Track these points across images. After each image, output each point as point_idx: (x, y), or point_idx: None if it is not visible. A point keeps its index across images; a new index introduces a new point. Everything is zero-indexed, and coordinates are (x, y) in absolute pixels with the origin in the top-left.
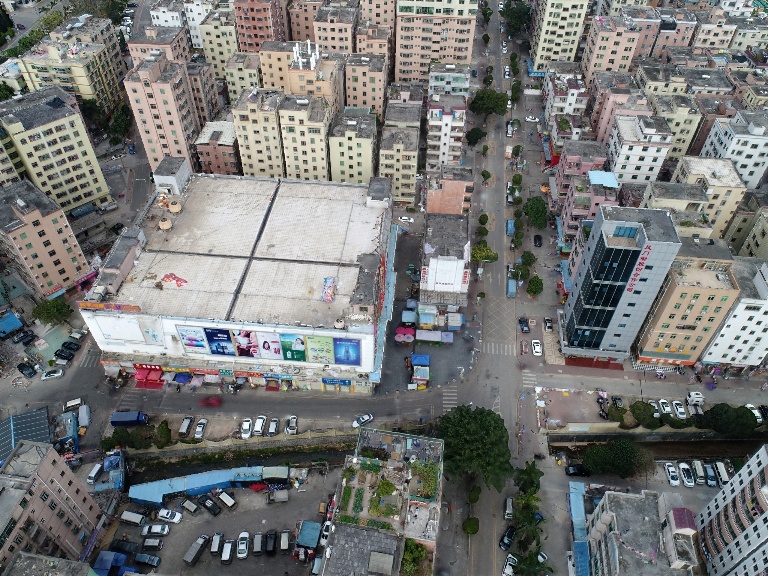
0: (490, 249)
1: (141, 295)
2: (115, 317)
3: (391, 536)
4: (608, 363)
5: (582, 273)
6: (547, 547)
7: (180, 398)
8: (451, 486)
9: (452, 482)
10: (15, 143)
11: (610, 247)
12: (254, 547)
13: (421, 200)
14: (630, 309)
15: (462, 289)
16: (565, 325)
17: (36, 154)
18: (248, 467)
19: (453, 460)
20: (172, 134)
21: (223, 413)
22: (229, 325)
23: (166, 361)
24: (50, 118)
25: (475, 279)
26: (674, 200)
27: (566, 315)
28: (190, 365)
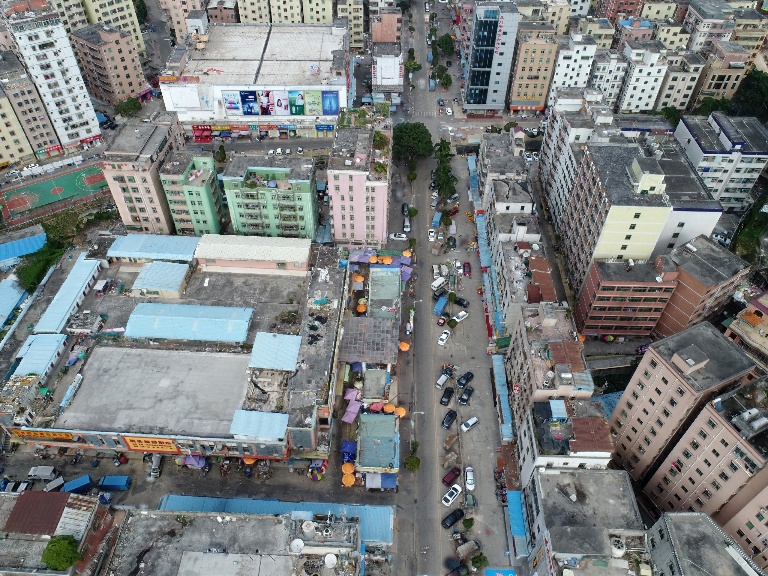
0: (416, 63)
1: None
2: (183, 87)
3: (367, 130)
4: (493, 116)
5: (470, 51)
6: (456, 187)
7: (225, 146)
8: (400, 169)
9: (400, 168)
10: (86, 3)
11: (481, 20)
12: None
13: (368, 47)
14: (499, 68)
15: (399, 82)
16: (465, 95)
17: (100, 11)
18: None
19: (399, 145)
20: (191, 0)
21: (254, 150)
22: (256, 87)
23: (214, 123)
24: None
25: (408, 83)
26: (524, 8)
27: (465, 88)
28: (230, 124)
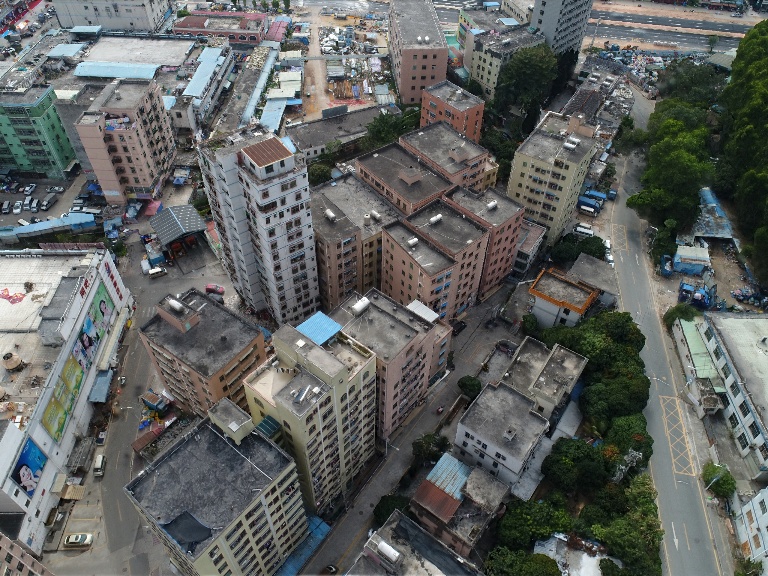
0: None
1: (49, 277)
2: None
3: None
4: None
5: None
6: None
7: None
8: None
9: None
10: None
11: None
12: (8, 202)
13: None
14: None
15: None
16: None
17: None
18: (2, 235)
19: None
20: None
21: None
22: None
23: None
24: (183, 475)
25: None
26: None
27: None
28: None
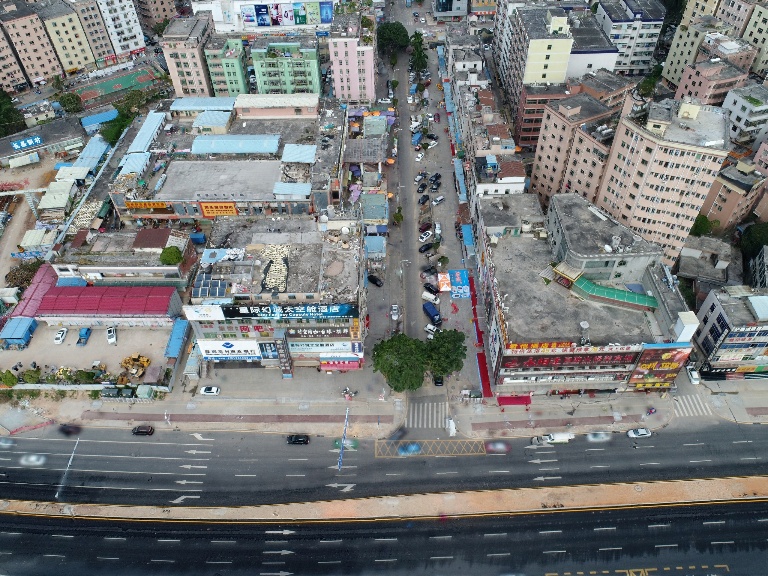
0: None
1: None
2: (209, 3)
3: (357, 15)
4: None
5: None
6: (429, 70)
7: None
8: None
9: (385, 60)
10: None
11: None
12: None
13: None
14: None
15: None
16: (435, 6)
17: None
18: None
19: (383, 39)
20: None
21: None
22: (267, 1)
23: (234, 34)
24: None
25: (389, 3)
26: None
27: (435, 1)
28: (247, 34)
